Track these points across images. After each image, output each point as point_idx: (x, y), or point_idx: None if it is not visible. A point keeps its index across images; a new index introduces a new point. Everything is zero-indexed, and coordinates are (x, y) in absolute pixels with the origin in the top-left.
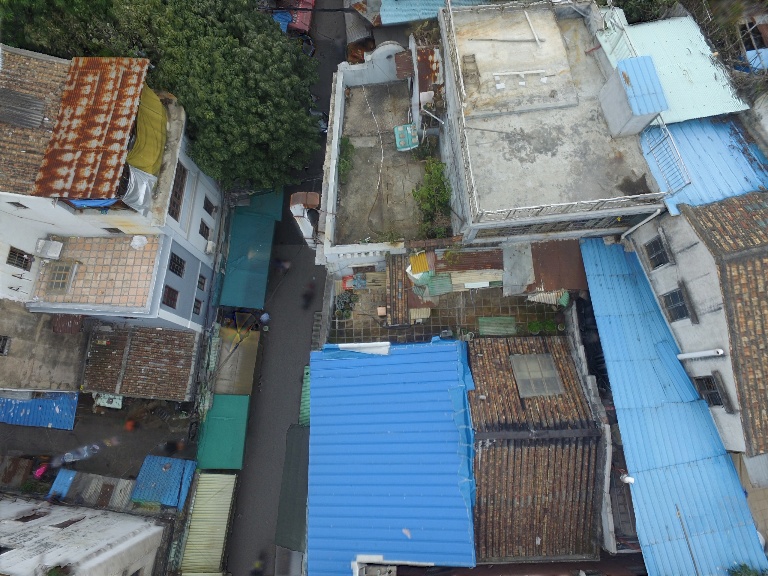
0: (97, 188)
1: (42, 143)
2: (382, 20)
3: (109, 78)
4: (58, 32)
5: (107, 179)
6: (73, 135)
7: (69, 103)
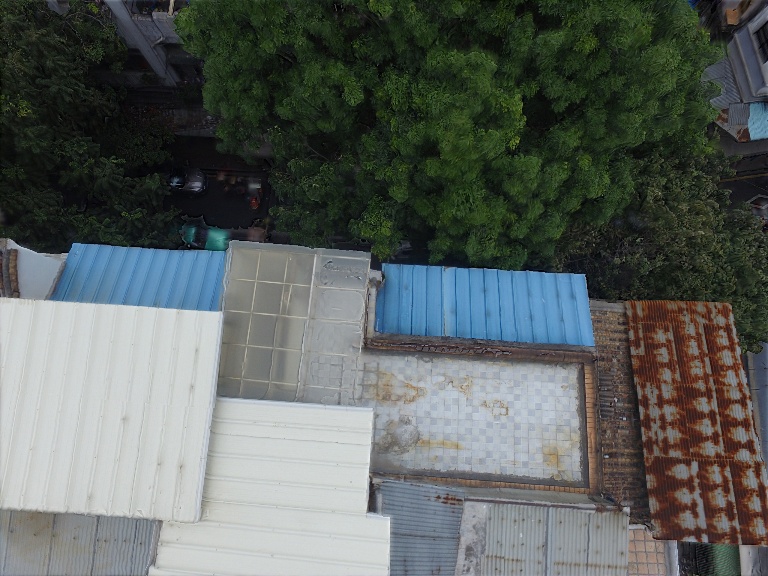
0: (747, 528)
1: (619, 438)
2: (751, 135)
3: (688, 336)
4: (577, 253)
5: (755, 512)
6: (673, 432)
7: (647, 377)
